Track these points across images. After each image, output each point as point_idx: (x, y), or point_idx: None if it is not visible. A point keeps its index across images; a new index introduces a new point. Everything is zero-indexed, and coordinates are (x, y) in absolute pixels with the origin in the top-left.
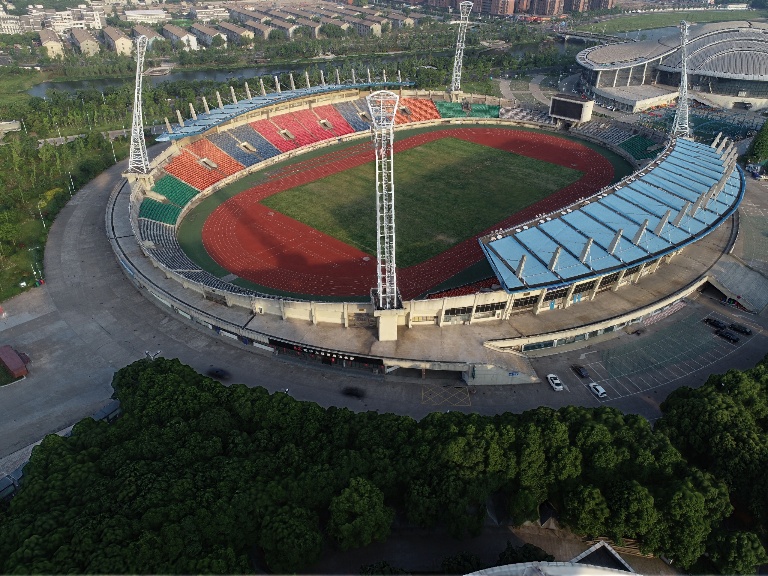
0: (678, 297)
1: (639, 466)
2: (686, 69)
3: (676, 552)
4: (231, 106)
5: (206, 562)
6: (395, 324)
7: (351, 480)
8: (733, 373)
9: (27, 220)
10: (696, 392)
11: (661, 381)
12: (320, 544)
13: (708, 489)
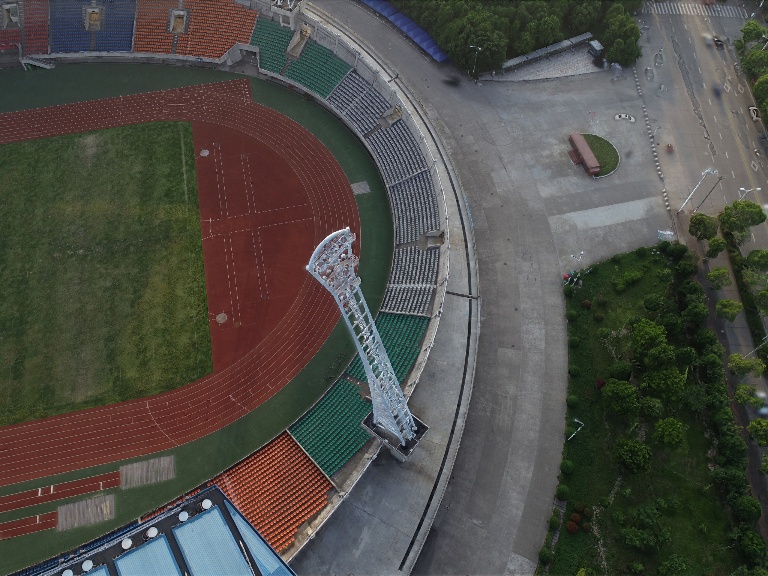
0: None
1: None
2: None
3: None
4: None
5: None
6: None
7: None
8: None
9: None
10: None
11: None
12: None
13: None
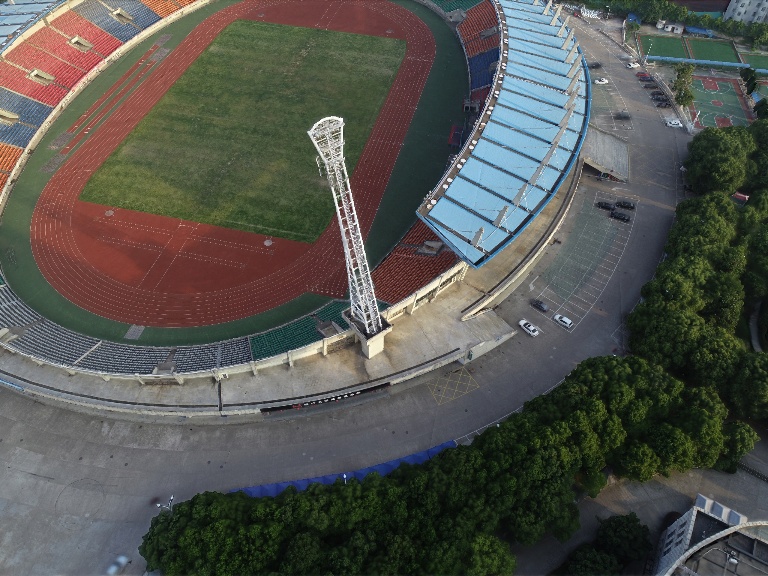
0: None
1: (661, 408)
2: None
3: (705, 463)
4: None
5: None
6: (382, 339)
7: (474, 547)
8: (670, 278)
9: None
10: (656, 309)
11: (600, 288)
12: None
13: (715, 408)
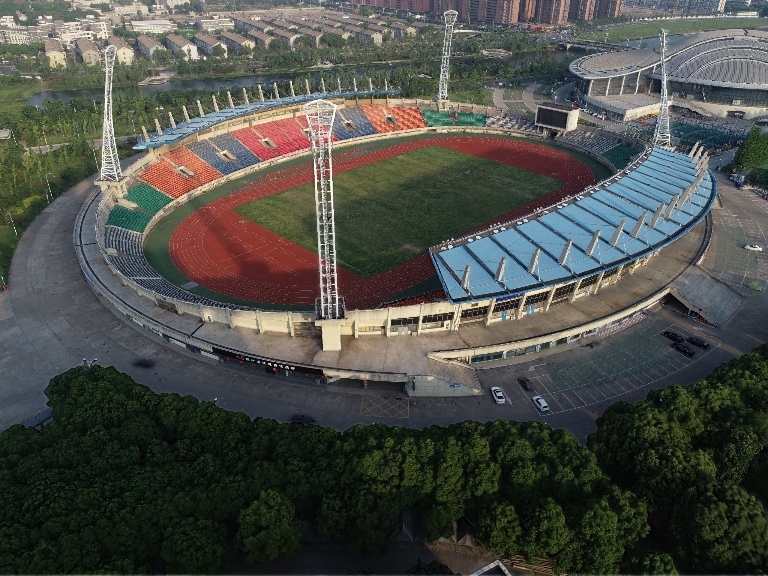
0: (636, 309)
1: (557, 483)
2: (679, 77)
3: (587, 573)
4: (212, 115)
5: (100, 573)
6: (338, 334)
7: (261, 492)
8: (672, 388)
9: (1, 227)
10: (631, 407)
11: (608, 395)
12: (223, 557)
13: (623, 508)
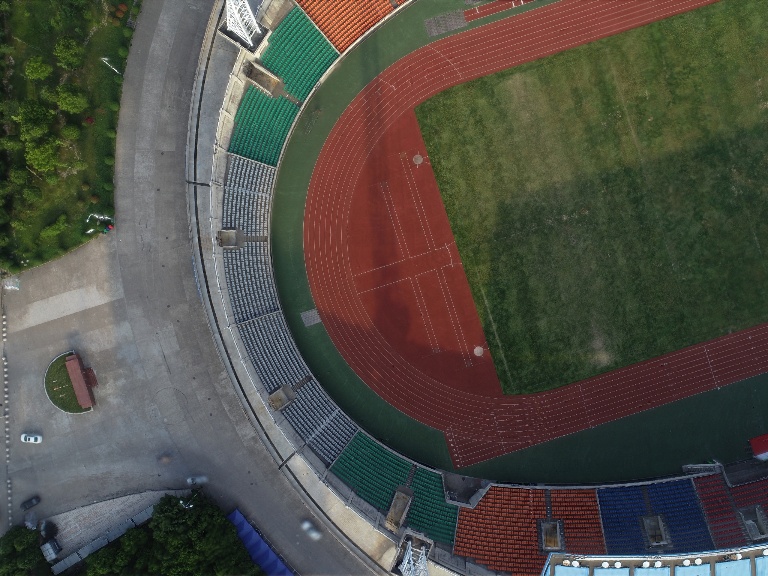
0: None
1: None
2: None
3: None
4: None
5: None
6: None
7: None
8: None
9: None
10: None
11: None
12: None
13: None
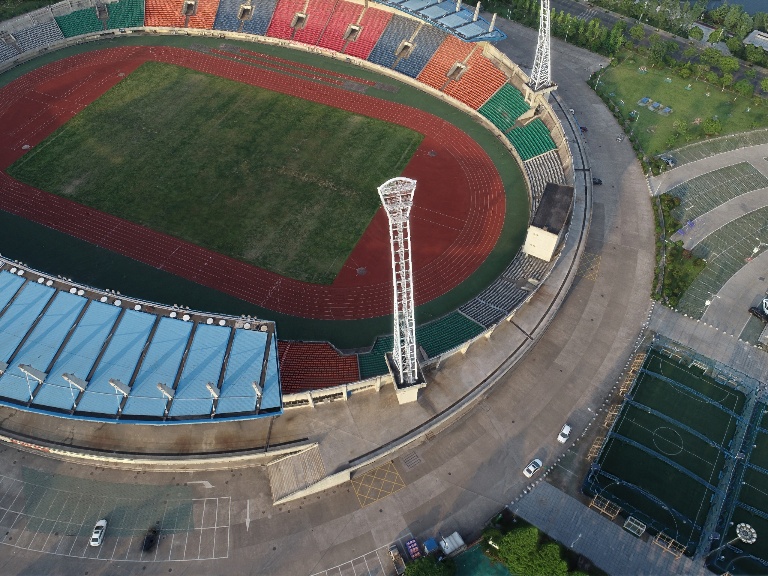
0: None
1: None
2: None
3: None
4: None
5: None
6: None
7: None
8: None
9: None
10: None
11: None
12: None
13: None
